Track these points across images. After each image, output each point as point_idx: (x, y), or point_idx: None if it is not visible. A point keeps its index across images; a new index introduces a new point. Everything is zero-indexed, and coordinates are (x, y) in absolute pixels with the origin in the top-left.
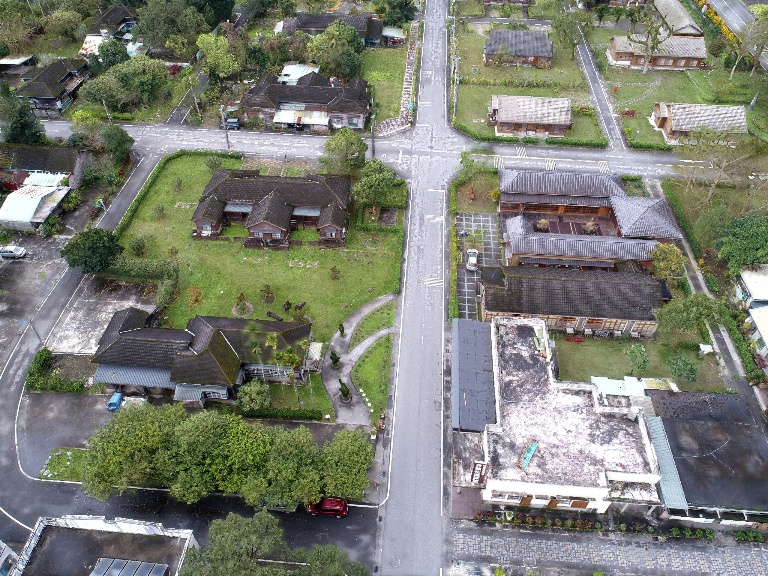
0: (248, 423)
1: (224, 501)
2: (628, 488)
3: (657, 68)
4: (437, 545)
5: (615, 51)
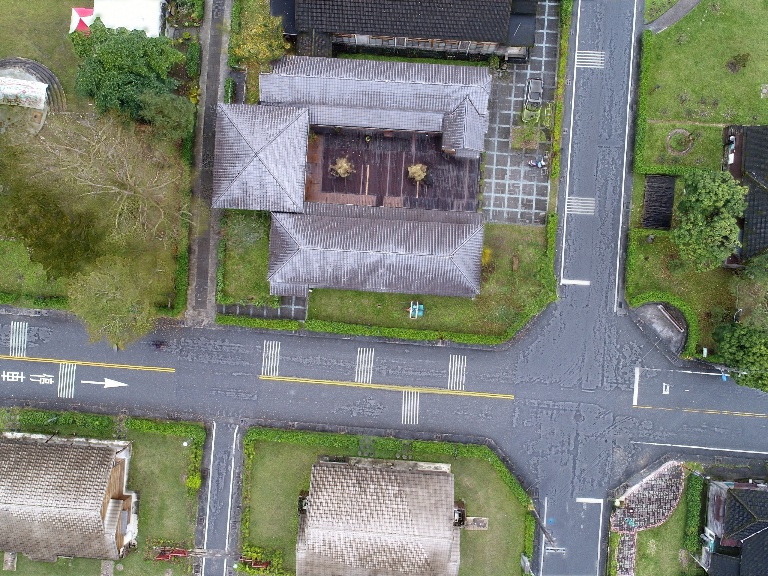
0: None
1: None
2: None
3: None
4: None
5: None
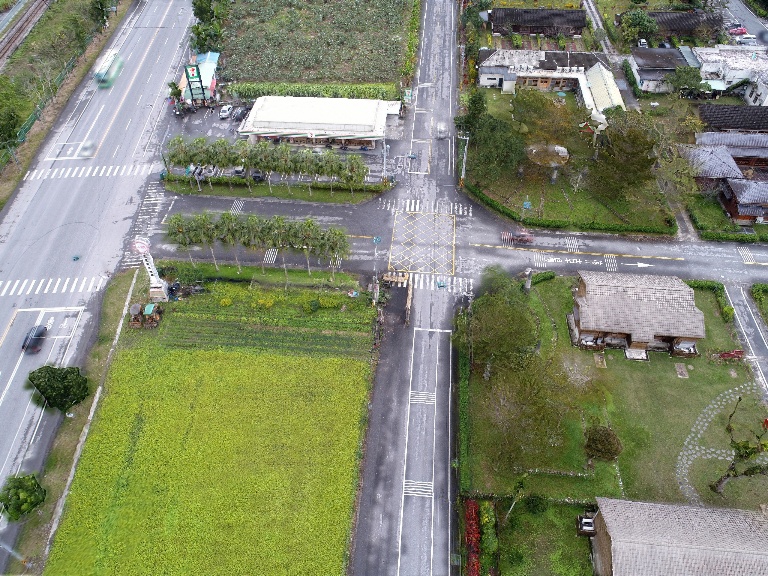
0: None
1: None
2: None
3: None
4: None
5: None
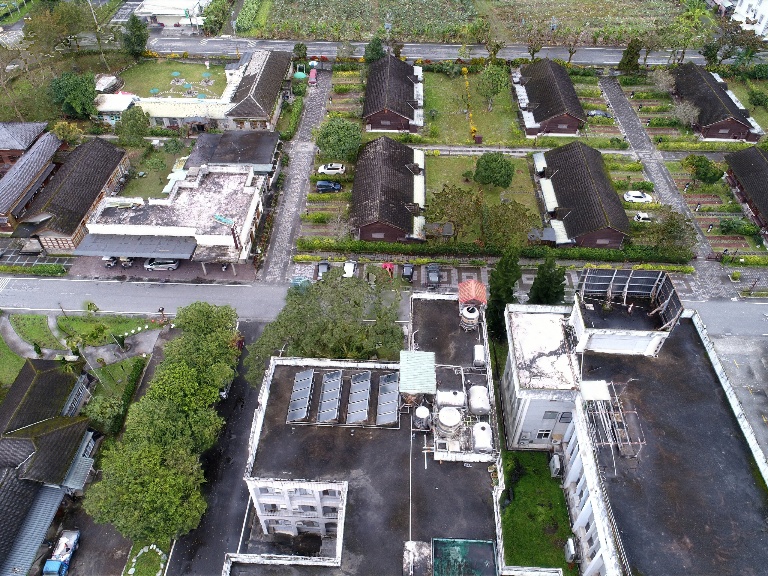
0: None
1: None
2: None
3: None
4: (273, 289)
5: None
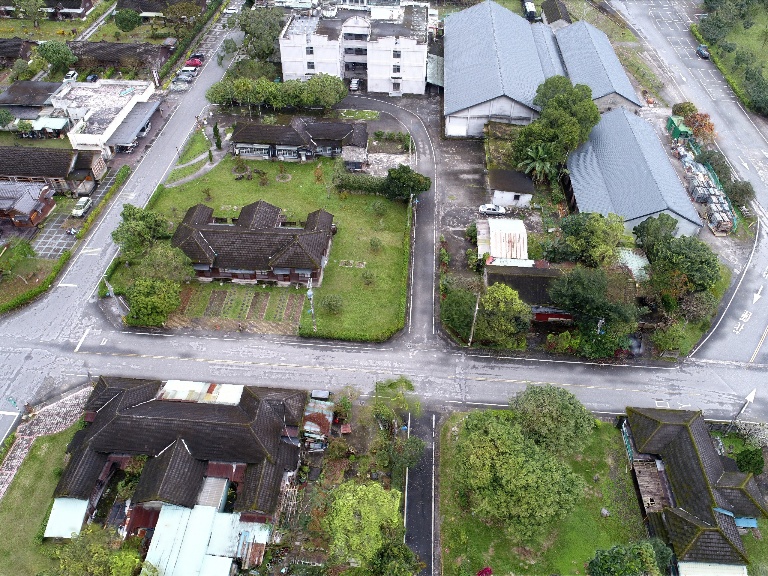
0: None
1: None
2: None
3: None
4: None
5: None
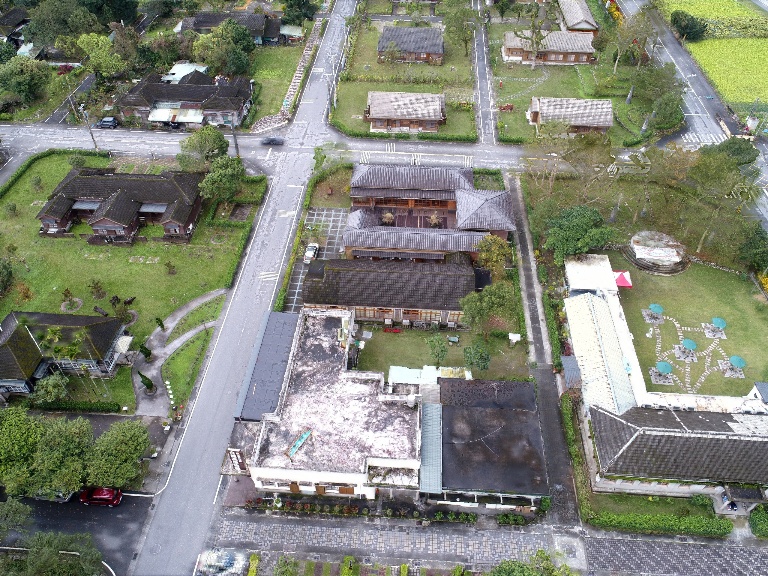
0: (46, 416)
1: (2, 492)
2: (391, 474)
3: (548, 63)
4: (202, 532)
5: (505, 47)
